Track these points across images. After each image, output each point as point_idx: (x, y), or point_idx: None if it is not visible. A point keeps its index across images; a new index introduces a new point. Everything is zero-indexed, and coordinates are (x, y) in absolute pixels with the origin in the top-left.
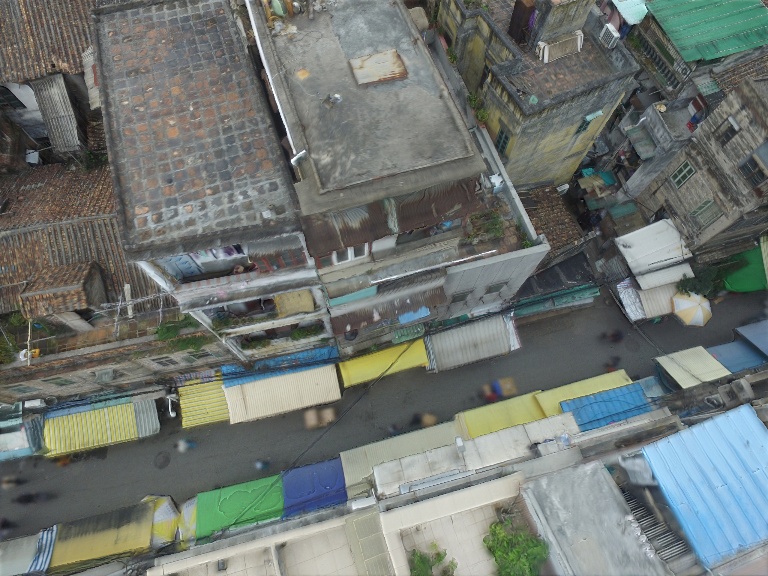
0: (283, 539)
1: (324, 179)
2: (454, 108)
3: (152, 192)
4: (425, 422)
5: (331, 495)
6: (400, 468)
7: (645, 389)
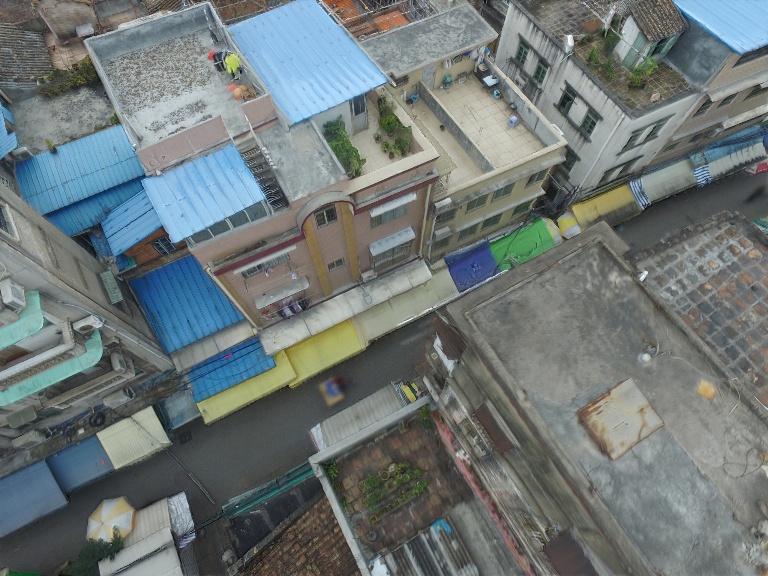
0: (491, 172)
1: (605, 255)
2: (504, 374)
3: (761, 273)
4: (390, 352)
5: (459, 256)
6: (411, 280)
7: (185, 412)
